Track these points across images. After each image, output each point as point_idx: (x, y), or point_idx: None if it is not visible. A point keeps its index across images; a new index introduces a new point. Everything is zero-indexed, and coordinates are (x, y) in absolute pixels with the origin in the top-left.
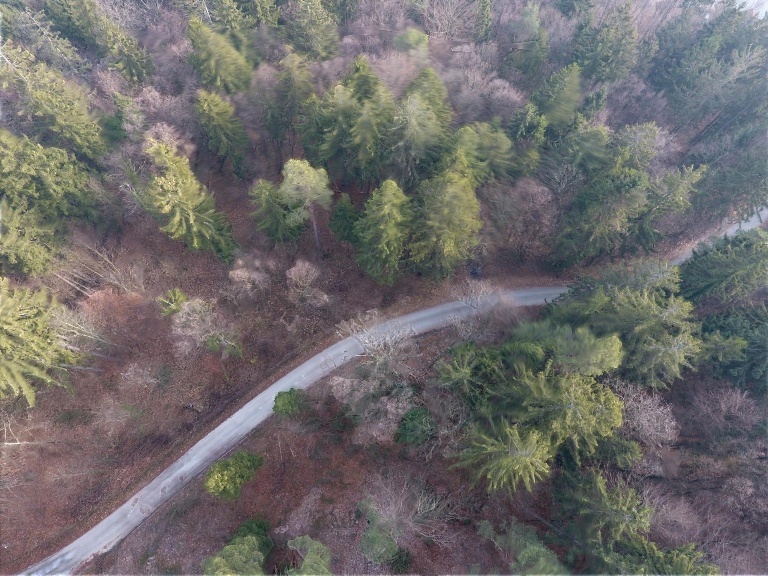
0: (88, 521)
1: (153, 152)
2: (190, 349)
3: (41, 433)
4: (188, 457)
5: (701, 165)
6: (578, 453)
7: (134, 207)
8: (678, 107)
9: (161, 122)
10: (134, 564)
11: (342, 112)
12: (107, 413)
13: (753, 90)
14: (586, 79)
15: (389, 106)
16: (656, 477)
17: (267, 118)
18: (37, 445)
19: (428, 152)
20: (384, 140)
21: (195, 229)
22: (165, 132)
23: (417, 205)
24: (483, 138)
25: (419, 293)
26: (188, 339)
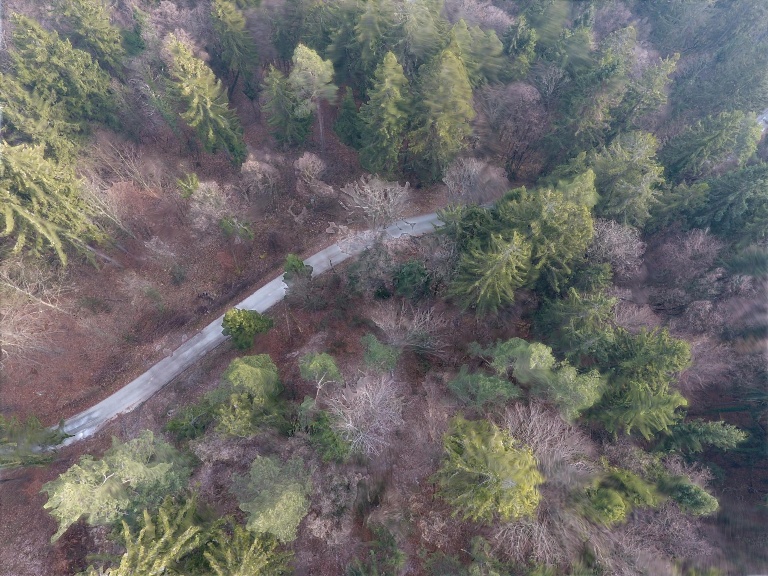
0: (112, 386)
1: (172, 50)
2: (207, 225)
3: (67, 316)
4: (203, 335)
5: (675, 54)
6: (557, 281)
7: (153, 110)
8: (662, 35)
9: (178, 28)
10: (155, 421)
11: (347, 12)
12: (131, 281)
13: (731, 13)
14: (575, 6)
15: (390, 8)
16: (626, 300)
17: (276, 34)
18: (63, 325)
19: (426, 54)
20: (385, 41)
21: (211, 115)
22: (182, 36)
23: (415, 90)
24: (477, 42)
25: (417, 202)
26: (205, 216)
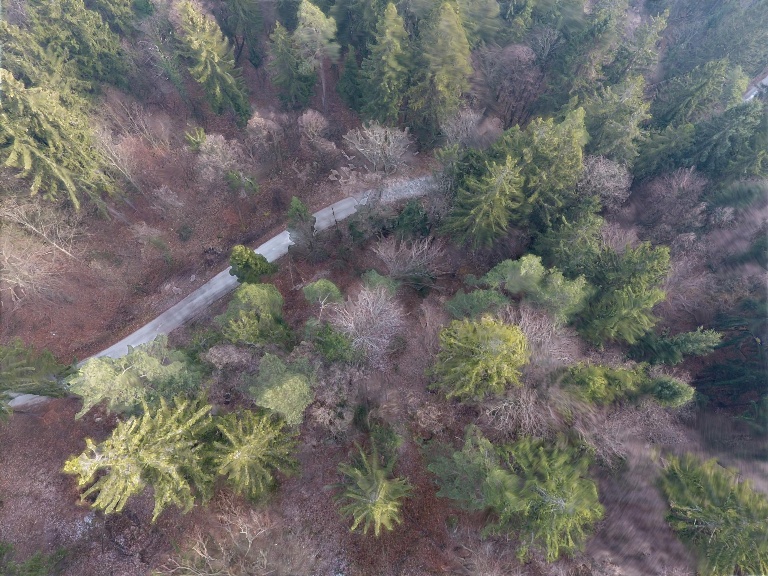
0: (122, 332)
1: (181, 10)
2: (214, 176)
3: None
4: (210, 285)
5: (665, 10)
6: (549, 215)
7: (161, 71)
8: None
9: None
10: None
11: None
12: (141, 229)
13: None
14: None
15: None
16: None
17: (280, 1)
18: (74, 277)
19: (425, 16)
20: (386, 2)
21: (219, 70)
22: None
23: (415, 45)
24: (475, 5)
25: (417, 165)
26: (212, 168)
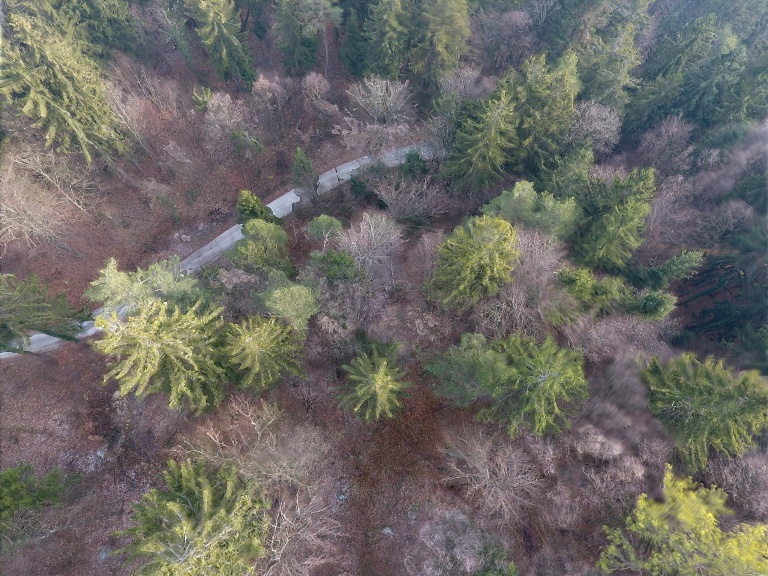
0: None
1: None
2: (220, 134)
3: (88, 228)
4: (216, 243)
5: None
6: (543, 159)
7: (169, 37)
8: None
9: None
10: None
11: None
12: (150, 184)
13: None
14: None
15: None
16: None
17: None
18: (85, 235)
19: None
20: None
21: (225, 31)
22: None
23: (415, 6)
24: None
25: None
26: None
